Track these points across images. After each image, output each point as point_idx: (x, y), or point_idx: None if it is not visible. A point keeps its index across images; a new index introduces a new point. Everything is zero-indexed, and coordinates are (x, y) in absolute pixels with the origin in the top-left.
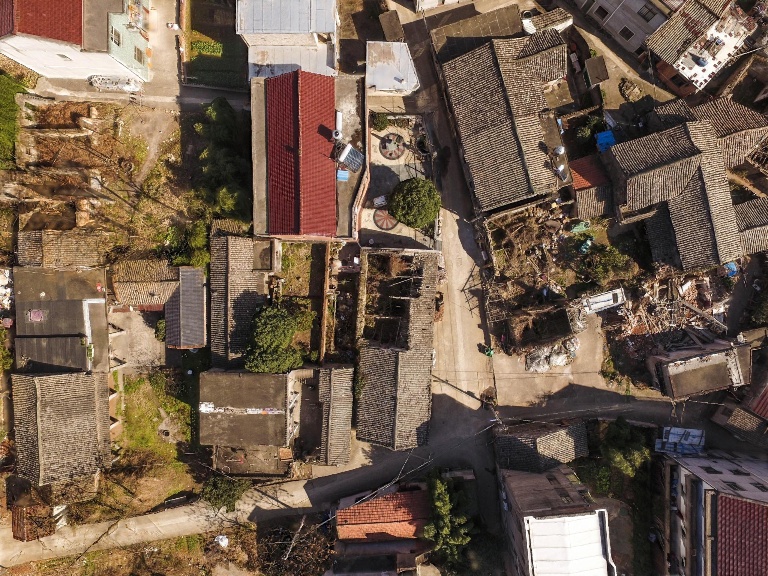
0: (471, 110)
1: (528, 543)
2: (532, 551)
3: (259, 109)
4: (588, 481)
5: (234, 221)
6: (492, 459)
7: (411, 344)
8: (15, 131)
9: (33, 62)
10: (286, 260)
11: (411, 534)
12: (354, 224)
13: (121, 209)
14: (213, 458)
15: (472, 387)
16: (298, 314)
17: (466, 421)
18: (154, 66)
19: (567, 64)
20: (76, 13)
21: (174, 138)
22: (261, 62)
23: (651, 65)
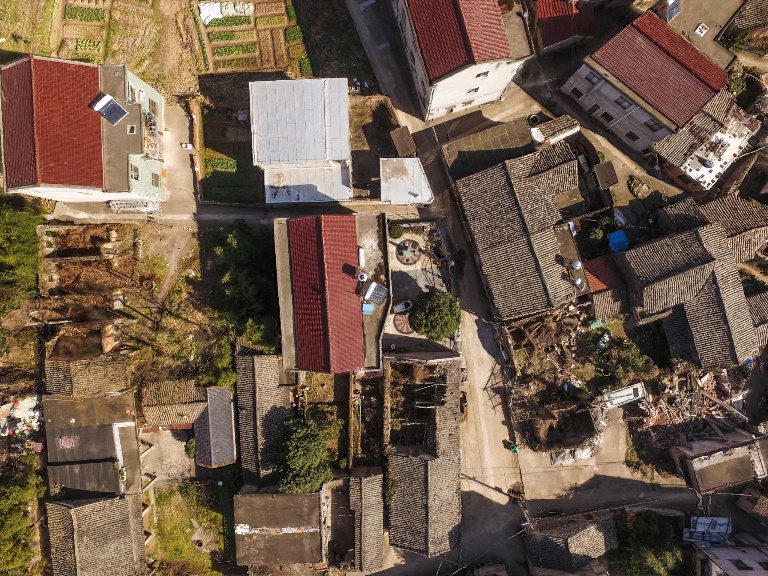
0: (487, 225)
1: None
2: None
3: (283, 248)
4: (619, 573)
5: (260, 346)
6: (523, 552)
7: (439, 451)
8: (38, 262)
9: (53, 196)
10: None
11: None
12: None
13: (144, 326)
14: (249, 572)
15: (499, 483)
16: (325, 426)
17: (495, 516)
18: (170, 185)
19: None
20: (96, 157)
21: (193, 254)
22: (277, 184)
23: None
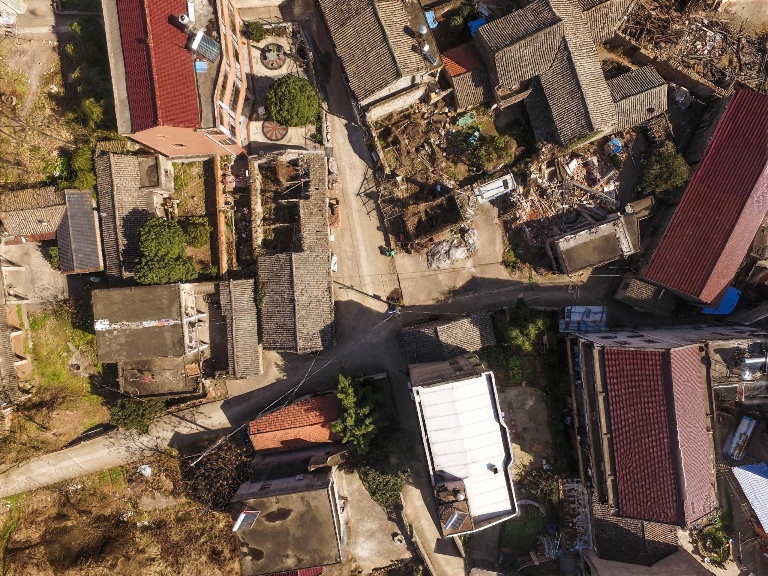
0: (336, 2)
1: (419, 413)
2: (425, 422)
3: (111, 8)
4: (498, 369)
5: (110, 134)
6: (404, 360)
7: (305, 246)
8: None
9: None
10: (178, 180)
11: (326, 438)
12: (217, 114)
13: (8, 145)
14: (120, 381)
15: (377, 290)
16: (191, 229)
17: (375, 325)
18: None
19: None
20: None
21: (54, 68)
22: None
23: None
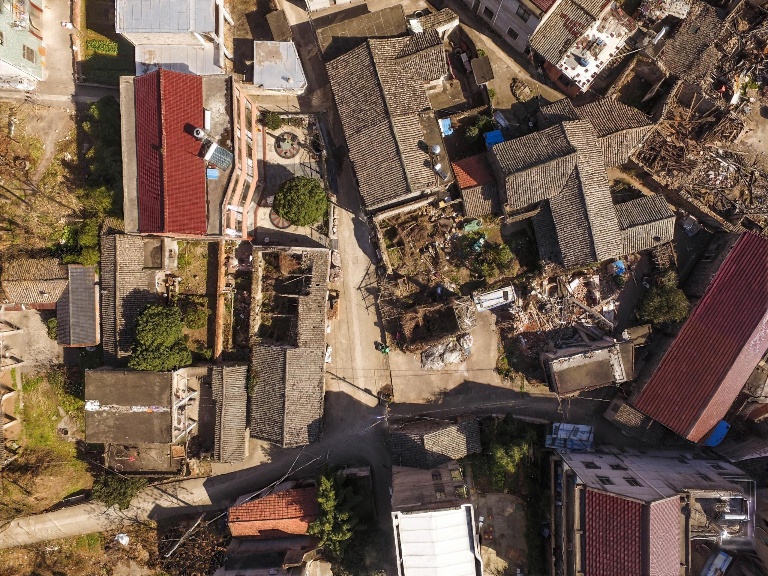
0: (353, 109)
1: (396, 538)
2: (401, 546)
3: (129, 108)
4: (481, 477)
5: (117, 219)
6: (389, 456)
7: (300, 342)
8: None
9: None
10: (182, 258)
11: (304, 531)
12: (224, 222)
13: (18, 208)
14: (105, 456)
15: (369, 384)
16: (190, 312)
17: (364, 418)
18: (49, 65)
19: (459, 64)
20: None
21: (70, 137)
22: (148, 61)
23: (539, 65)
